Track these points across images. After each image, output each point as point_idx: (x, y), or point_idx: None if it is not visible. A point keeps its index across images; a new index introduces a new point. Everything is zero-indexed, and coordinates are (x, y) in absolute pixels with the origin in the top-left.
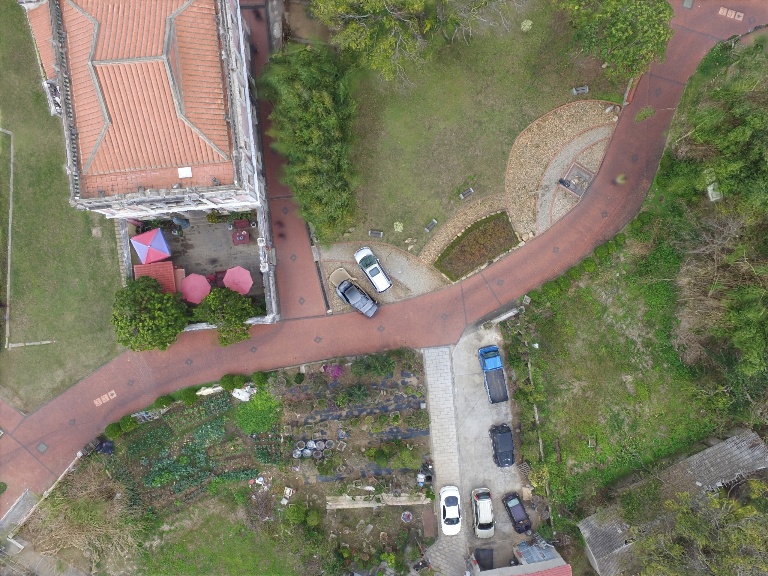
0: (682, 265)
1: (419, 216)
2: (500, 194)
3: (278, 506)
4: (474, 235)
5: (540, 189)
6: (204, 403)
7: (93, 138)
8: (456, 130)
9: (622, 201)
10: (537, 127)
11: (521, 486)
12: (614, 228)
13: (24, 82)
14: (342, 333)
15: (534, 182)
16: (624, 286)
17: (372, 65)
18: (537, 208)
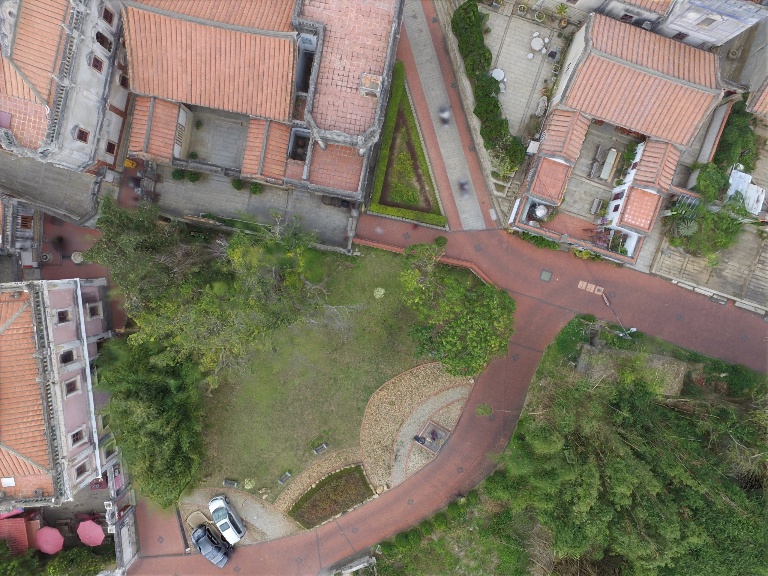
0: (536, 523)
1: (274, 467)
2: (355, 448)
3: None
4: (326, 491)
5: (395, 444)
6: None
7: None
8: (311, 386)
9: (478, 458)
10: (393, 385)
11: None
12: (469, 483)
13: None
14: (199, 572)
15: (389, 437)
16: (478, 539)
17: (200, 367)
18: (392, 462)
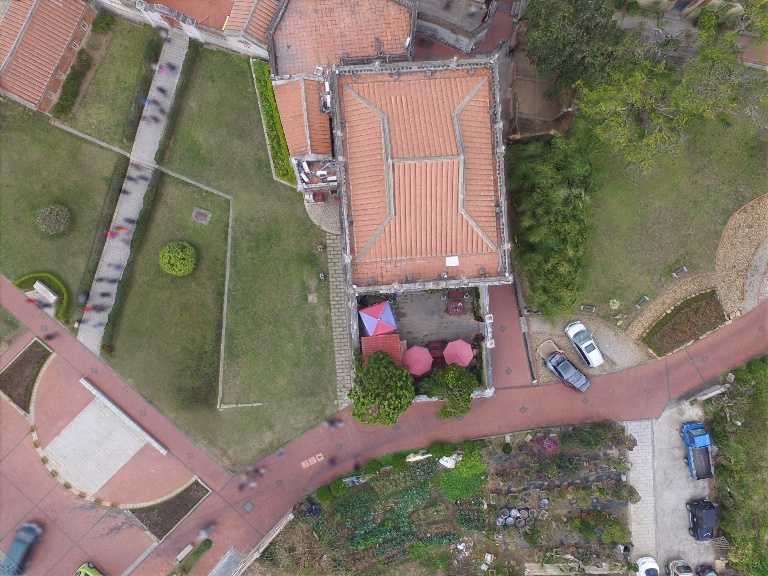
0: None
1: (630, 292)
2: (710, 273)
3: (478, 571)
4: (686, 314)
5: (750, 269)
6: (410, 469)
7: (371, 228)
8: (671, 209)
9: None
10: (751, 208)
11: (714, 558)
12: None
13: (246, 148)
14: (547, 404)
15: (744, 262)
16: None
17: (627, 156)
18: (745, 288)
